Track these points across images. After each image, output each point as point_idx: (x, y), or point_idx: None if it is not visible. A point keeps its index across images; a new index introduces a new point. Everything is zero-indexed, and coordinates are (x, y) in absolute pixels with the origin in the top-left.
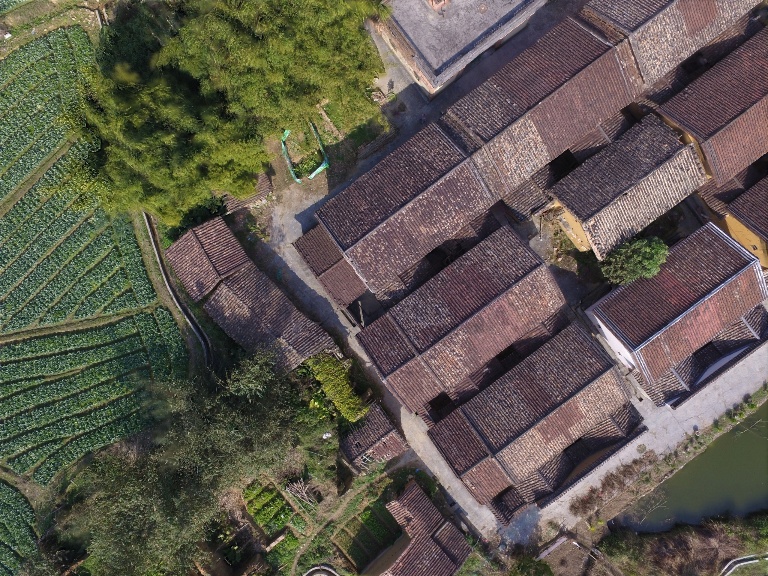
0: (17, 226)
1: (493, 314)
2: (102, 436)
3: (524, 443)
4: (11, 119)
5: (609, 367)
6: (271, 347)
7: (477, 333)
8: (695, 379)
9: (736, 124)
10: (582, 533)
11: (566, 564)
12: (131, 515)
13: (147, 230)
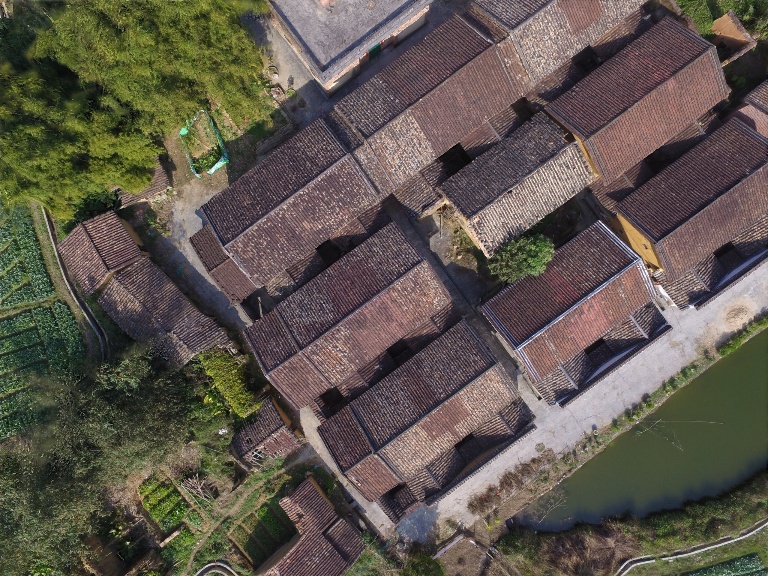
0: None
1: (376, 310)
2: None
3: (408, 440)
4: None
5: (492, 365)
6: (163, 342)
7: (360, 329)
8: (585, 378)
9: (618, 122)
10: (480, 531)
11: (463, 562)
12: (5, 508)
13: (46, 224)
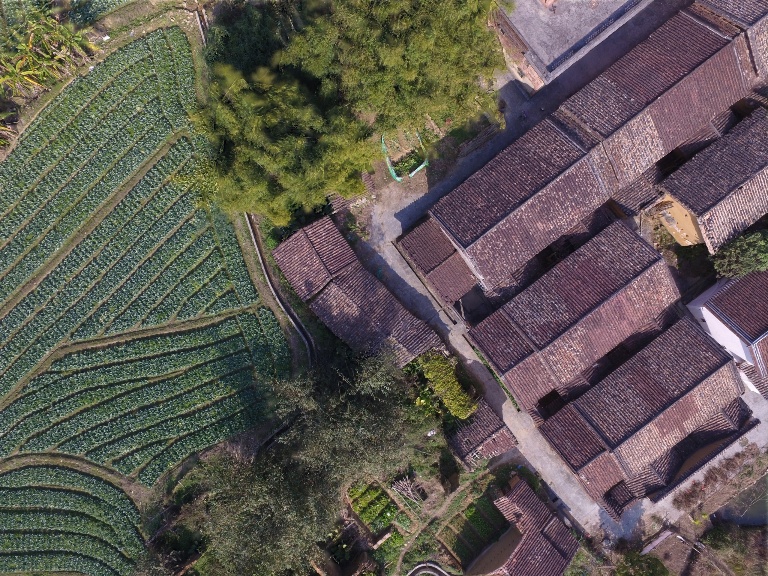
0: (118, 228)
1: (611, 309)
2: (207, 437)
3: (641, 437)
4: (111, 121)
5: (727, 361)
6: (380, 345)
7: (594, 328)
8: None
9: None
10: (685, 527)
11: (670, 558)
12: (258, 514)
13: (248, 230)
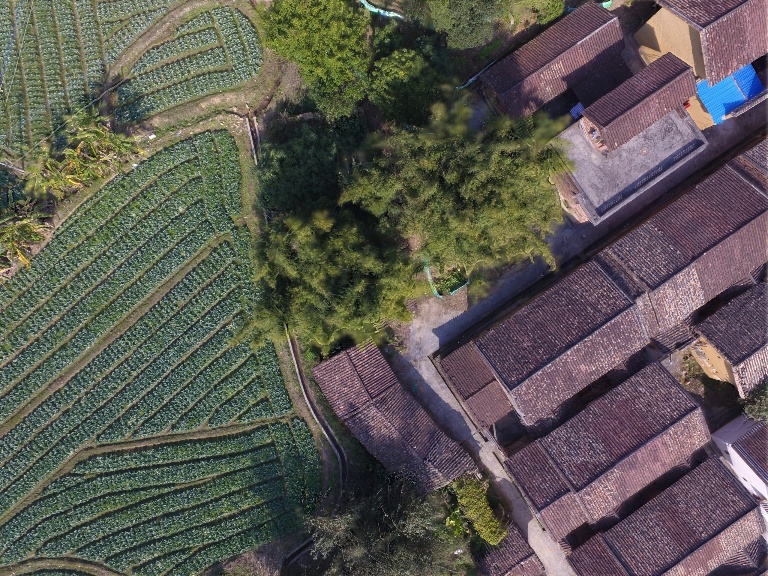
0: (153, 330)
1: (646, 453)
2: (232, 547)
3: None
4: (152, 222)
5: (753, 507)
6: (414, 468)
7: (629, 470)
8: None
9: None
10: None
11: None
12: None
13: (286, 340)
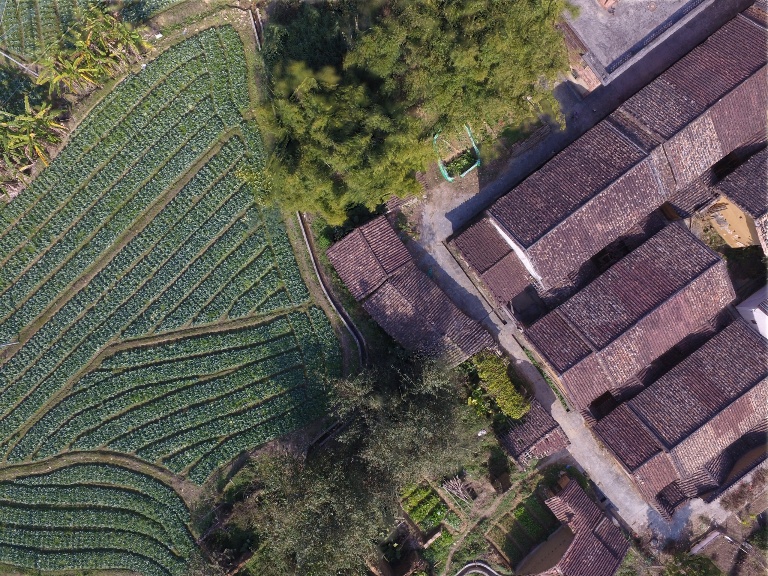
0: (169, 226)
1: (669, 310)
2: (257, 435)
3: (697, 438)
4: (163, 119)
5: None
6: (433, 345)
7: (652, 329)
8: None
9: None
10: (732, 527)
11: (717, 558)
12: (319, 513)
13: (300, 229)
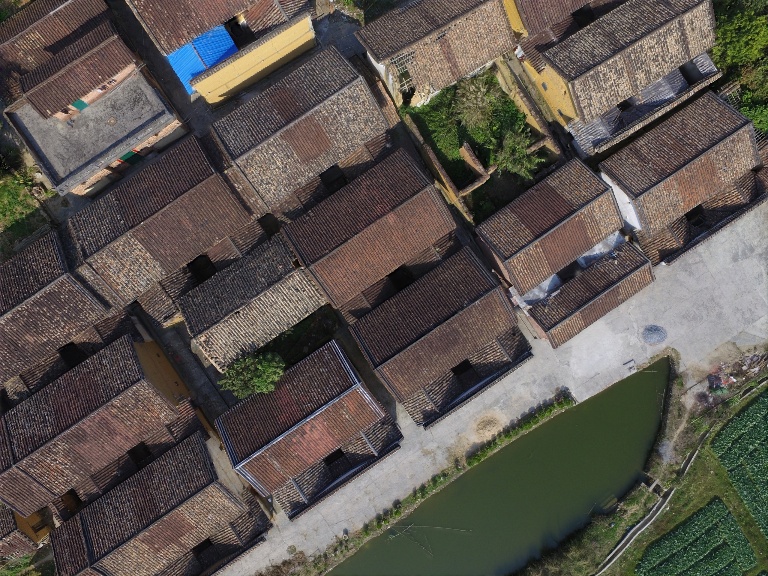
0: None
1: (95, 425)
2: None
3: (126, 553)
4: None
5: (210, 482)
6: None
7: (81, 443)
8: (319, 491)
9: (340, 252)
10: None
11: None
12: None
13: None
